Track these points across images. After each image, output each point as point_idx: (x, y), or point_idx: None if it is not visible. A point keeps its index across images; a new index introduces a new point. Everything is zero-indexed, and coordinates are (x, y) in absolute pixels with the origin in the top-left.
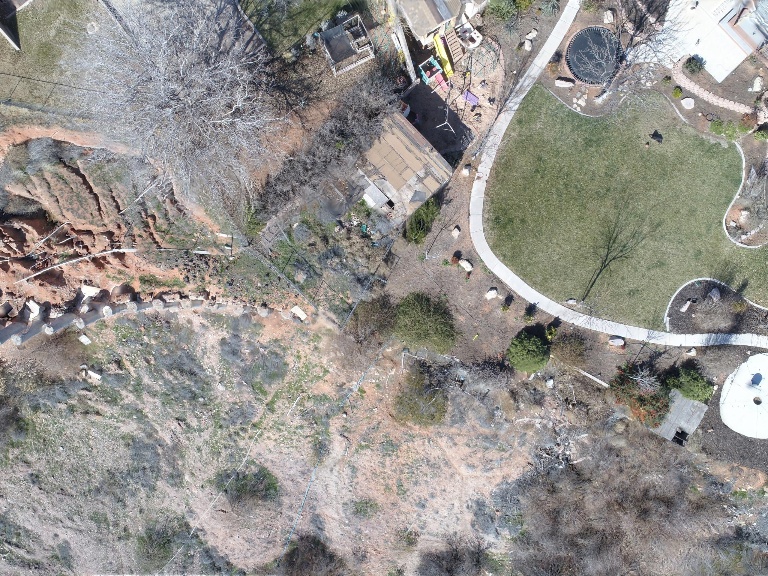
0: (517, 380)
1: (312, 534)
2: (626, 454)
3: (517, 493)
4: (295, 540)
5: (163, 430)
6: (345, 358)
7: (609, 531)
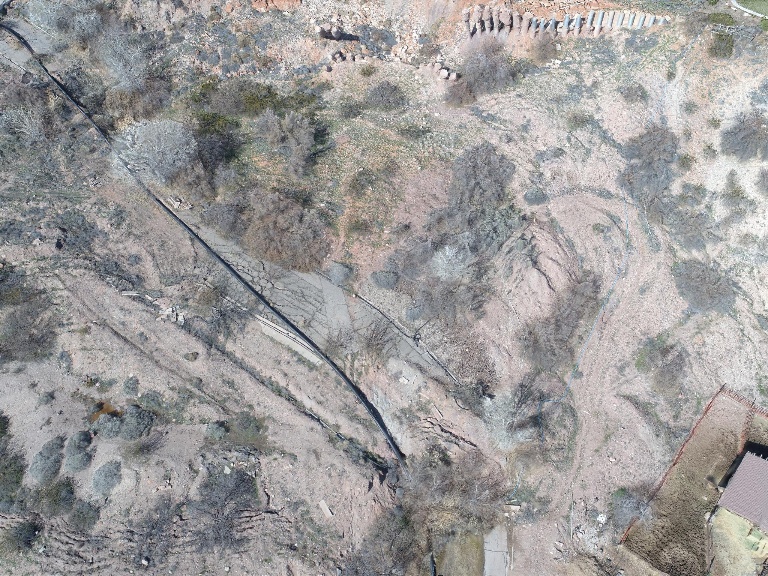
0: (764, 34)
1: (659, 128)
2: None
3: None
4: None
5: (589, 77)
6: (687, 31)
7: None
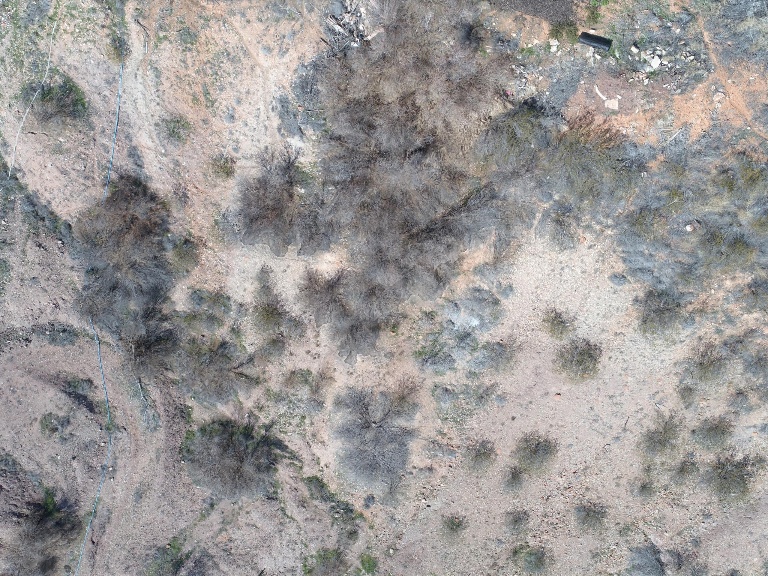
0: None
1: (133, 175)
2: (412, 12)
3: (317, 82)
4: (115, 180)
5: None
6: None
7: (405, 110)
